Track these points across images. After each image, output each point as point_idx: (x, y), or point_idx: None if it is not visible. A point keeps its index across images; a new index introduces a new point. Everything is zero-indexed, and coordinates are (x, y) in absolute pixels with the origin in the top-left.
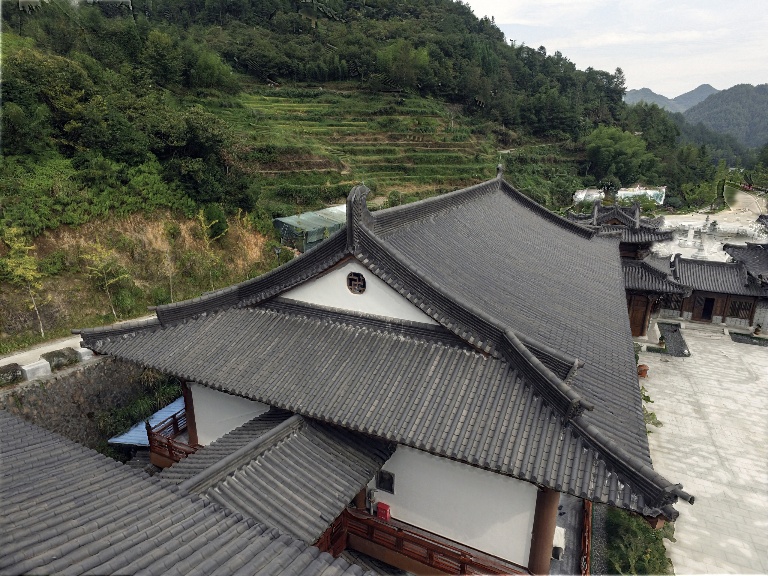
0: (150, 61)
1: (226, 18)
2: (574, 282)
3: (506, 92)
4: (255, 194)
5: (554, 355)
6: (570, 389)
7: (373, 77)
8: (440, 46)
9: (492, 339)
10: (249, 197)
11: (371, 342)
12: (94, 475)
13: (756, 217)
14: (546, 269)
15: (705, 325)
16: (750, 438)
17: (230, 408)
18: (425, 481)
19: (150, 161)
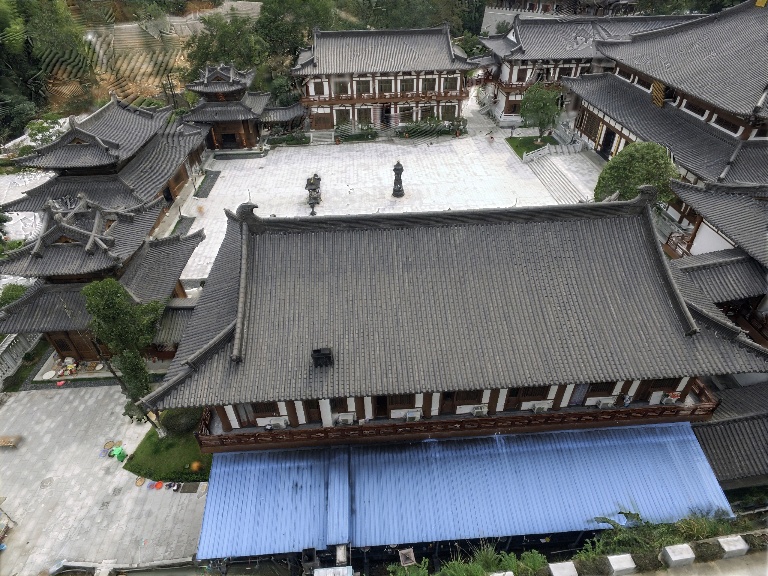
0: None
1: None
2: None
3: None
4: None
5: None
6: None
7: None
8: None
9: None
10: None
11: None
12: None
13: None
14: None
15: None
16: None
17: None
18: None
19: None
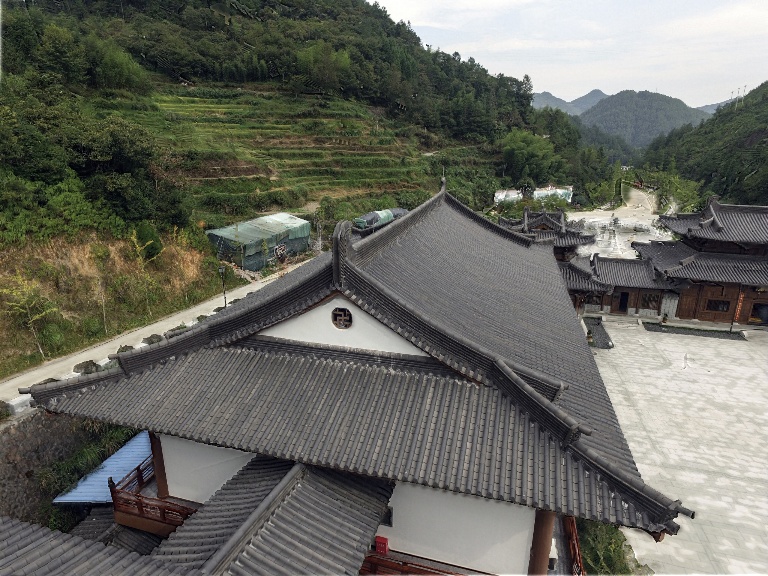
0: (48, 58)
1: (128, 10)
2: (529, 295)
3: (426, 96)
4: (188, 208)
5: (541, 380)
6: (567, 415)
7: (295, 79)
8: (360, 49)
9: (482, 368)
10: (183, 212)
11: (362, 377)
12: (112, 575)
13: (648, 212)
14: (503, 284)
15: (622, 317)
16: (673, 420)
17: (207, 455)
18: (424, 511)
19: (69, 177)
